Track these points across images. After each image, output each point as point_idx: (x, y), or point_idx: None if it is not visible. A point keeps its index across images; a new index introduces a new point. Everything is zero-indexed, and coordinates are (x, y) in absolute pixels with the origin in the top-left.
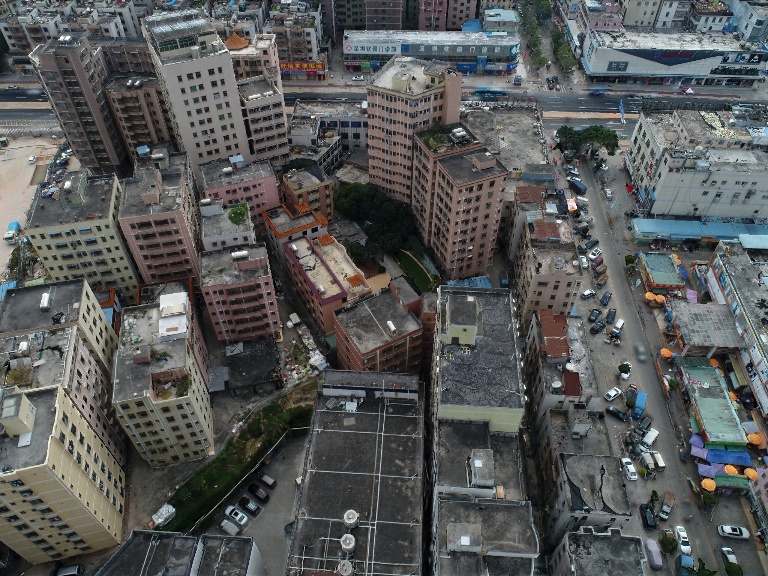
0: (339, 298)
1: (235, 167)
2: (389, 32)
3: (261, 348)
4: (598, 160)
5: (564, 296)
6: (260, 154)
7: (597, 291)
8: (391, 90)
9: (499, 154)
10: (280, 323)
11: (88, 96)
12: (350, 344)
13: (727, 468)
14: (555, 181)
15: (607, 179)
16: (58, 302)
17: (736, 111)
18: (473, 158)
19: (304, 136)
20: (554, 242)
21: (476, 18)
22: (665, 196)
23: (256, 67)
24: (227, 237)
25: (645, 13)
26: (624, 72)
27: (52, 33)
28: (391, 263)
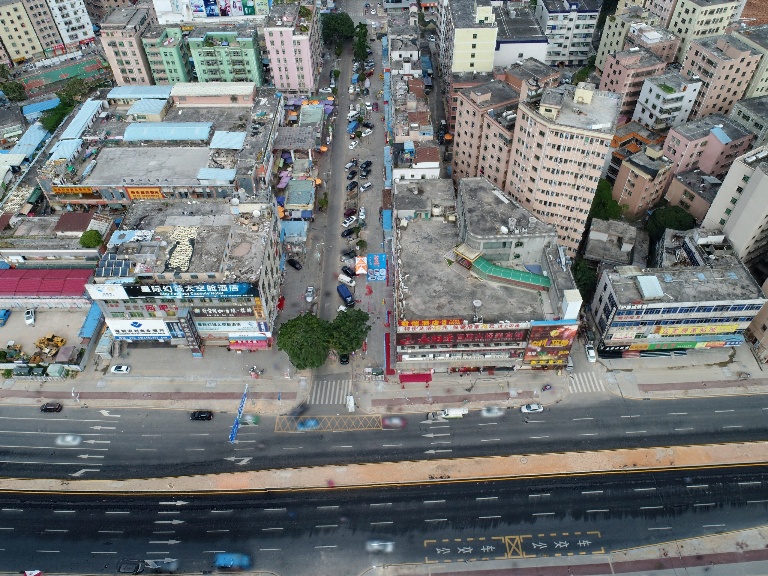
0: None
1: None
2: None
3: None
4: None
5: None
6: None
7: None
8: None
9: None
10: None
11: None
12: None
13: (318, 103)
14: (370, 311)
15: None
16: (703, 2)
17: (136, 272)
18: None
19: None
20: None
21: None
22: None
23: None
24: None
25: None
26: None
27: None
28: None
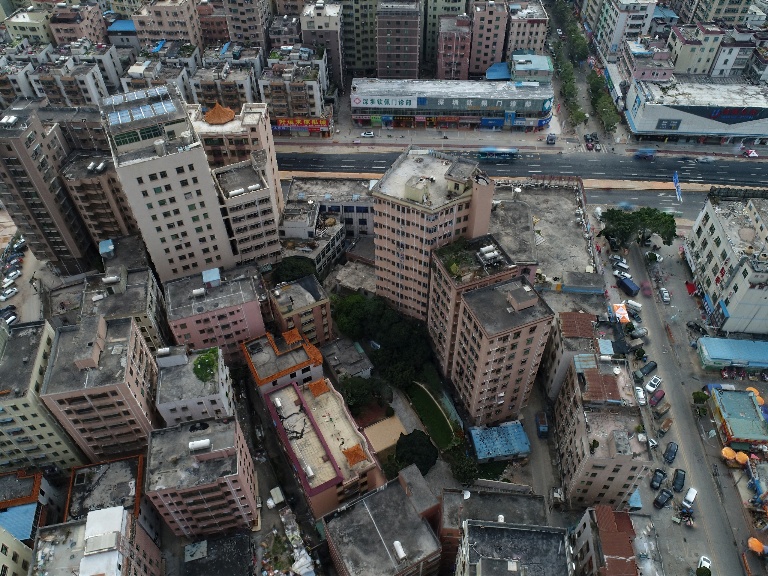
0: (332, 485)
1: (209, 286)
2: (403, 81)
3: (230, 549)
4: (650, 247)
5: (625, 478)
6: (245, 254)
7: (659, 440)
8: (403, 200)
9: (537, 265)
10: (258, 501)
11: (38, 186)
12: (344, 570)
13: None
14: None
15: (662, 274)
16: None
17: None
18: (508, 294)
19: (299, 228)
20: (612, 405)
21: (502, 61)
22: (742, 313)
23: (243, 146)
24: (189, 402)
25: (699, 60)
26: (676, 131)
27: (21, 85)
28: (401, 401)
